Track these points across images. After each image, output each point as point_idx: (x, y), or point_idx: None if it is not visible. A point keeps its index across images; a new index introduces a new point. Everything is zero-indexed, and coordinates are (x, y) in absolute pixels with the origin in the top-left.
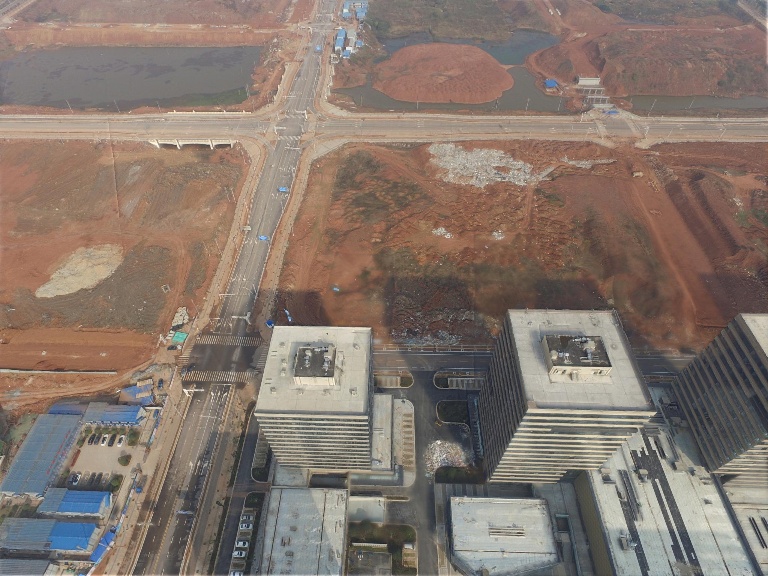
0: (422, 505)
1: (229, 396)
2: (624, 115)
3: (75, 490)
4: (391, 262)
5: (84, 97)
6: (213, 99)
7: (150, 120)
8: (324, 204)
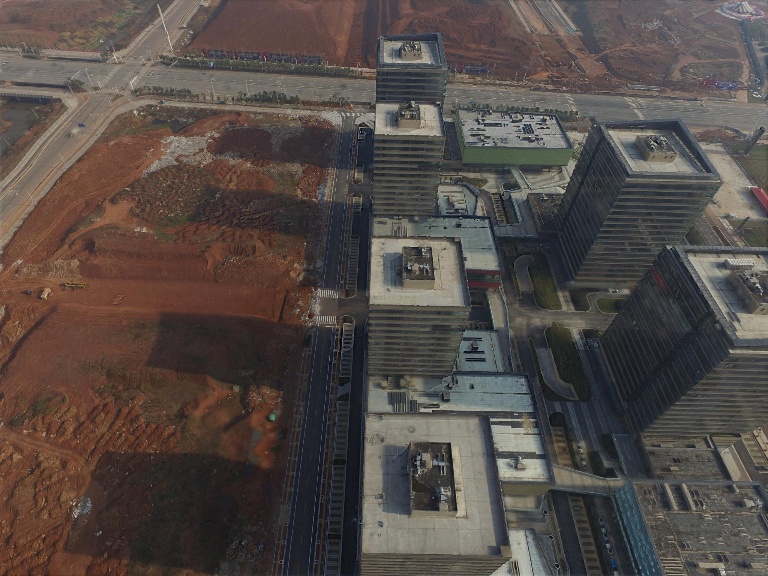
0: None
1: None
2: None
3: None
4: None
5: None
6: None
7: None
8: None
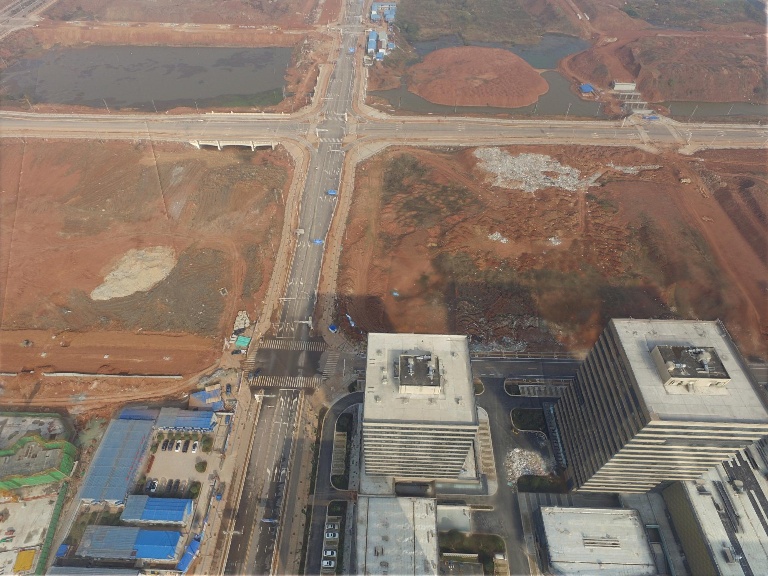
0: (508, 514)
1: (299, 402)
2: (664, 121)
3: (156, 497)
4: (451, 267)
5: (118, 96)
6: (248, 100)
7: (188, 121)
8: (374, 208)
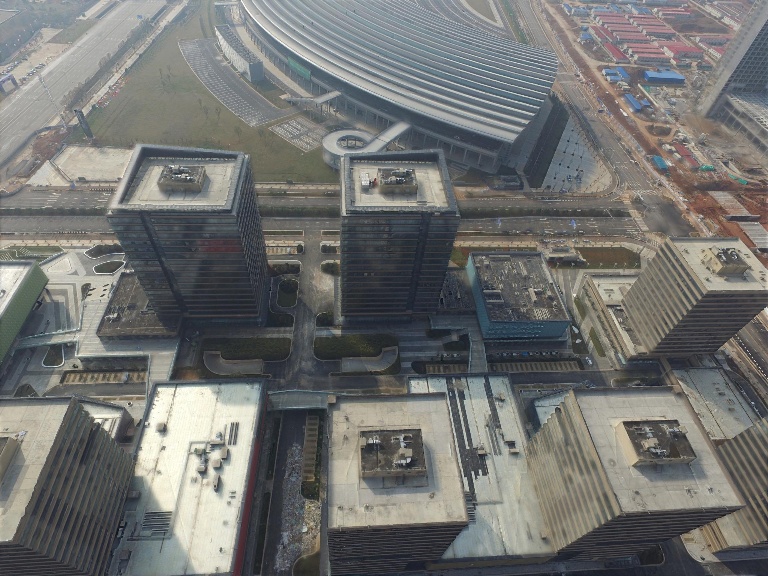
0: None
1: None
2: None
3: None
4: None
5: None
6: None
7: None
8: None
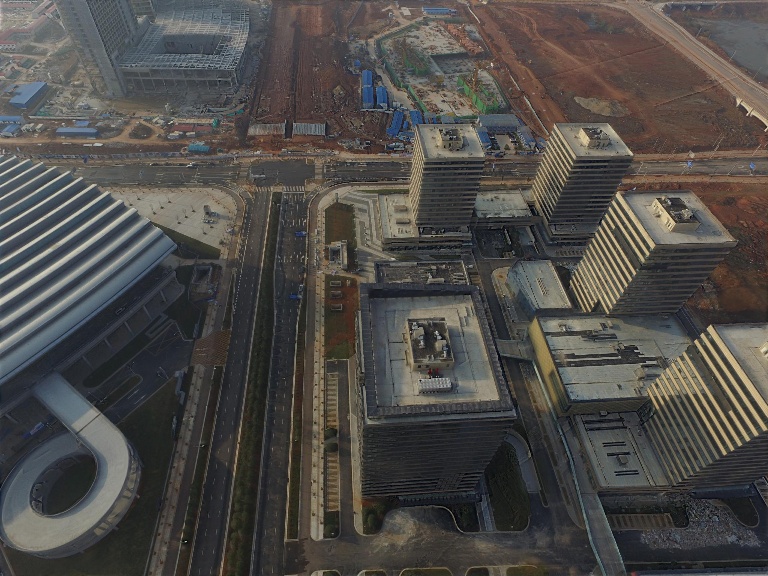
0: None
1: None
2: None
3: None
4: None
5: (754, 62)
6: None
7: (762, 92)
8: (760, 193)
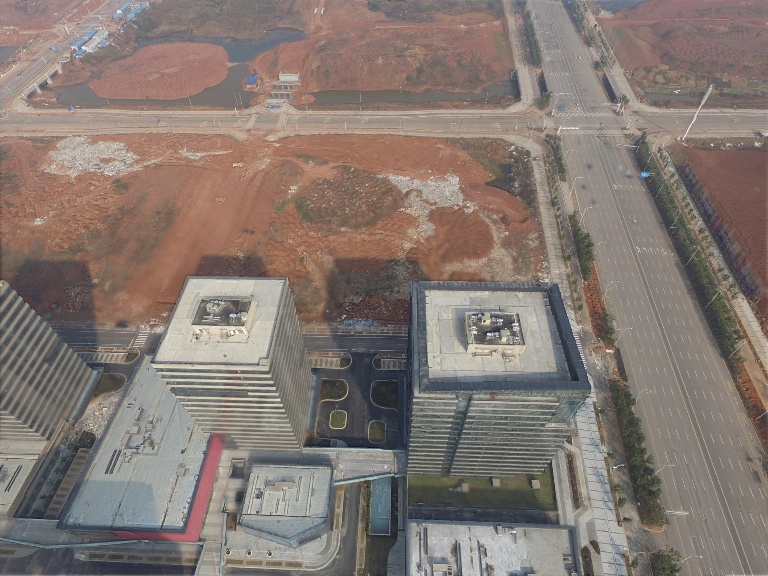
0: None
1: None
2: (284, 109)
3: None
4: None
5: None
6: None
7: None
8: None
